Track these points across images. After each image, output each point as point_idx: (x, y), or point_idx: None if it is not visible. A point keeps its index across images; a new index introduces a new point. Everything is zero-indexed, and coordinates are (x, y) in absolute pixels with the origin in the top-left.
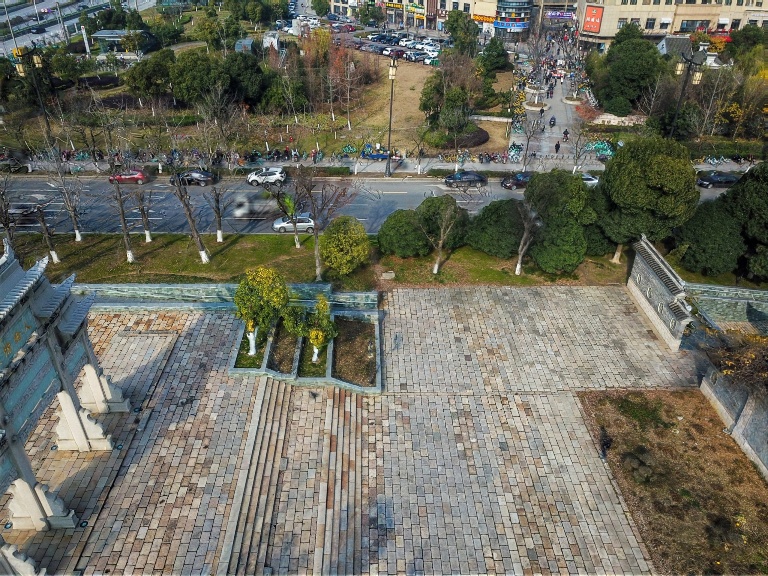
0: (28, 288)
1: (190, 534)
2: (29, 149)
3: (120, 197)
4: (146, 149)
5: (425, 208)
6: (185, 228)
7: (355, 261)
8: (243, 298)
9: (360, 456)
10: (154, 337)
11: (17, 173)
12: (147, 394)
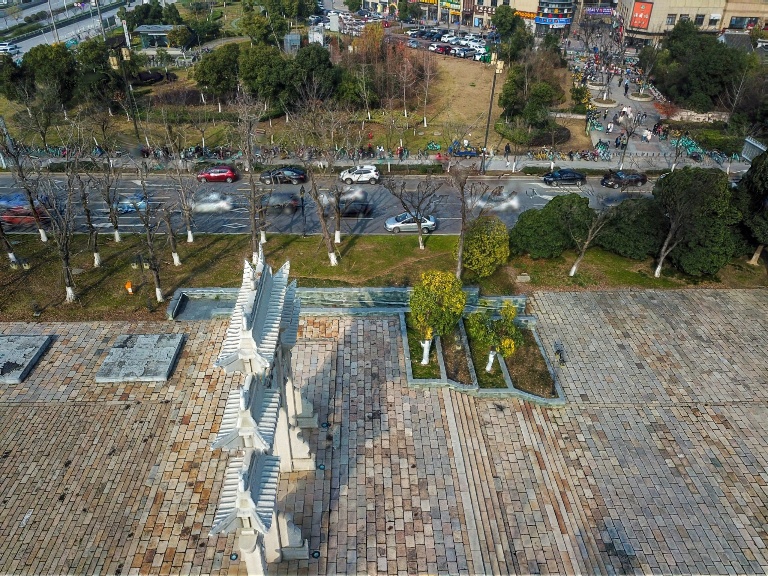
0: (284, 297)
1: (435, 565)
2: (148, 145)
3: (254, 196)
4: (268, 145)
5: (556, 207)
6: (293, 228)
7: (497, 263)
8: (421, 304)
9: (569, 474)
10: (313, 345)
11: (98, 171)
12: (329, 408)
